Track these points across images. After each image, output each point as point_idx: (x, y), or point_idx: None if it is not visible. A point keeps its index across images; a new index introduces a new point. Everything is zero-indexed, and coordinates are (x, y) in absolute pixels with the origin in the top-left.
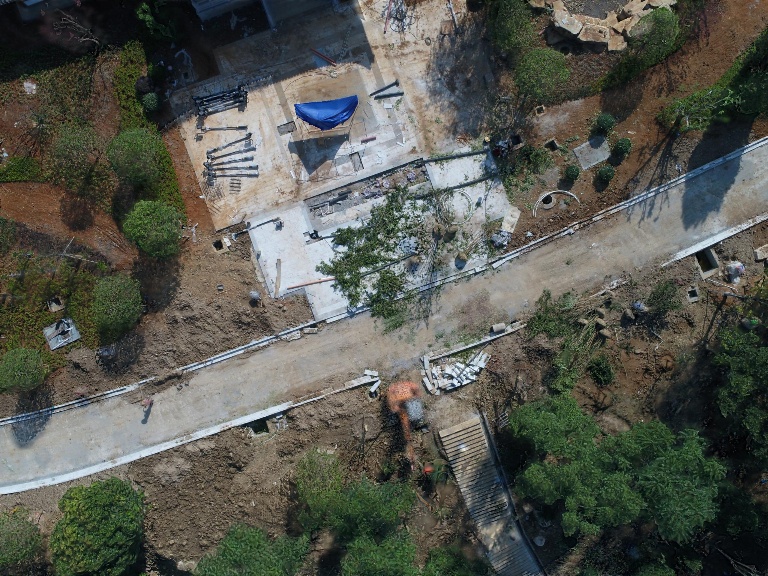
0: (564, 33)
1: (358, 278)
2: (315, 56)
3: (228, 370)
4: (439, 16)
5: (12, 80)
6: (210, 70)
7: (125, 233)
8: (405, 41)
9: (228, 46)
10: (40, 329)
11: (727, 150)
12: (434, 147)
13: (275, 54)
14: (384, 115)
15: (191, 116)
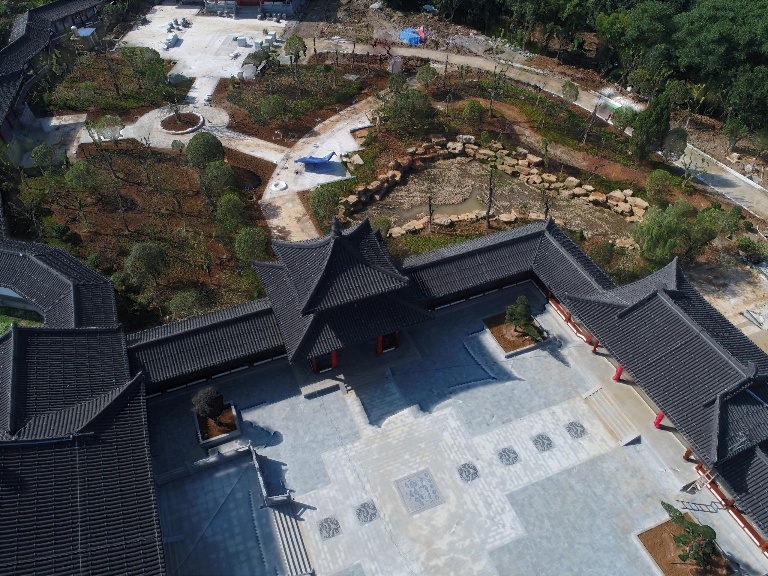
0: None
1: None
2: None
3: None
4: None
5: None
6: None
7: None
8: None
9: None
10: None
11: None
12: None
13: None
14: None
15: None
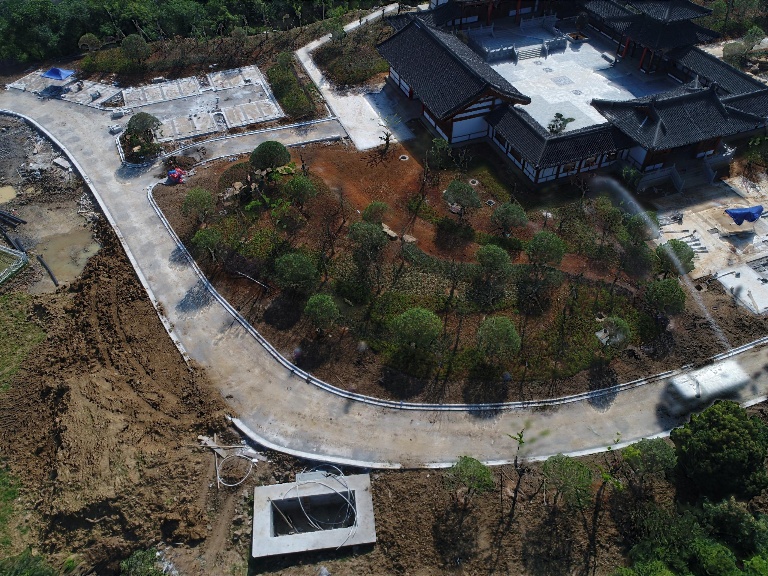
0: None
1: None
2: (712, 202)
3: (748, 359)
4: None
5: (534, 212)
6: (652, 209)
7: (634, 279)
8: (762, 195)
9: (657, 199)
10: (593, 332)
11: None
12: None
13: (688, 202)
14: None
15: None
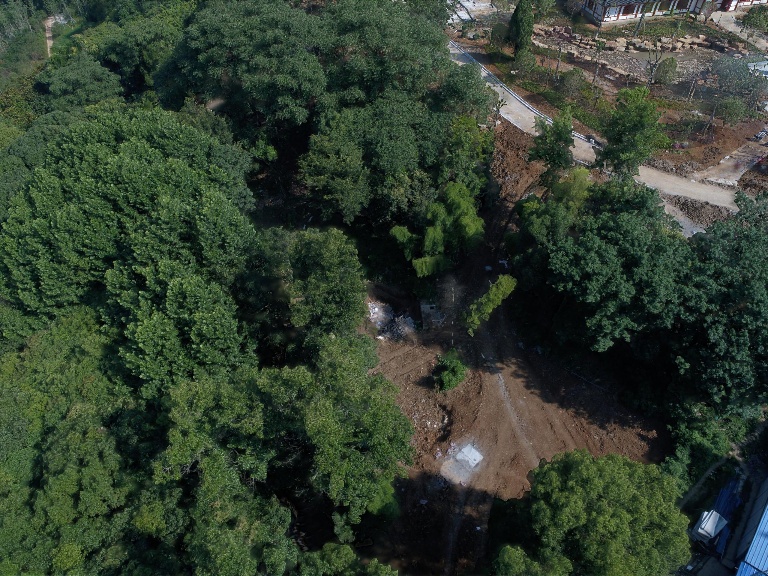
0: None
1: None
2: None
3: None
4: None
5: None
6: None
7: None
8: None
9: None
10: None
11: (478, 60)
12: None
13: None
14: None
15: None
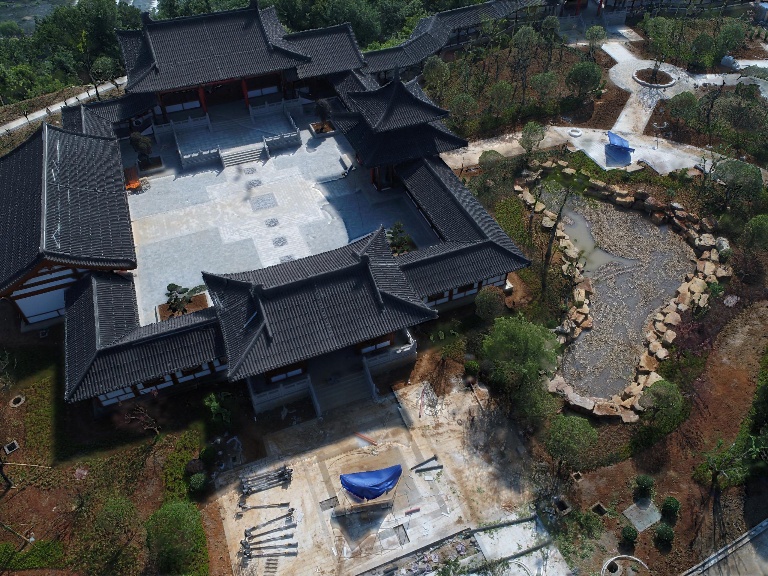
0: (580, 410)
1: None
2: (357, 438)
3: None
4: (466, 403)
5: (66, 468)
6: (258, 453)
7: None
8: (439, 423)
9: (277, 433)
10: None
11: None
12: (480, 516)
13: (320, 438)
14: (426, 487)
15: (234, 496)
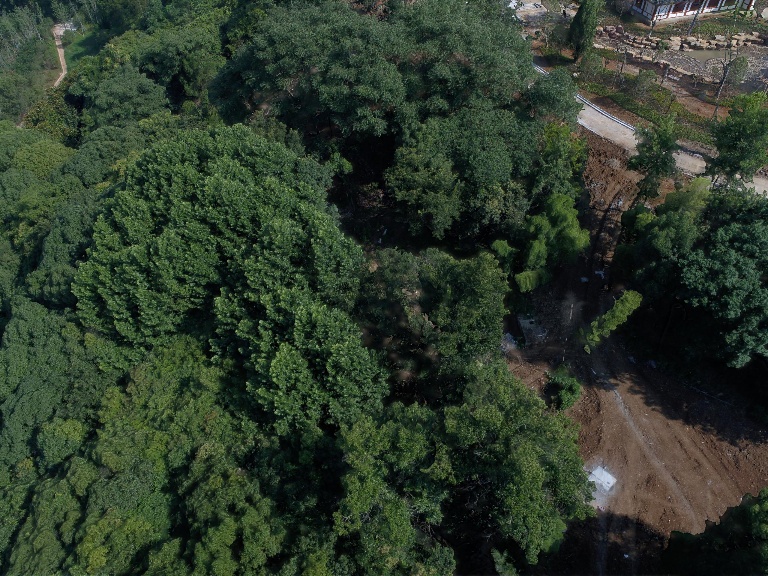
0: None
1: (463, 1)
2: None
3: None
4: (571, 13)
5: None
6: None
7: None
8: None
9: None
10: None
11: None
12: None
13: None
14: (528, 5)
15: None
